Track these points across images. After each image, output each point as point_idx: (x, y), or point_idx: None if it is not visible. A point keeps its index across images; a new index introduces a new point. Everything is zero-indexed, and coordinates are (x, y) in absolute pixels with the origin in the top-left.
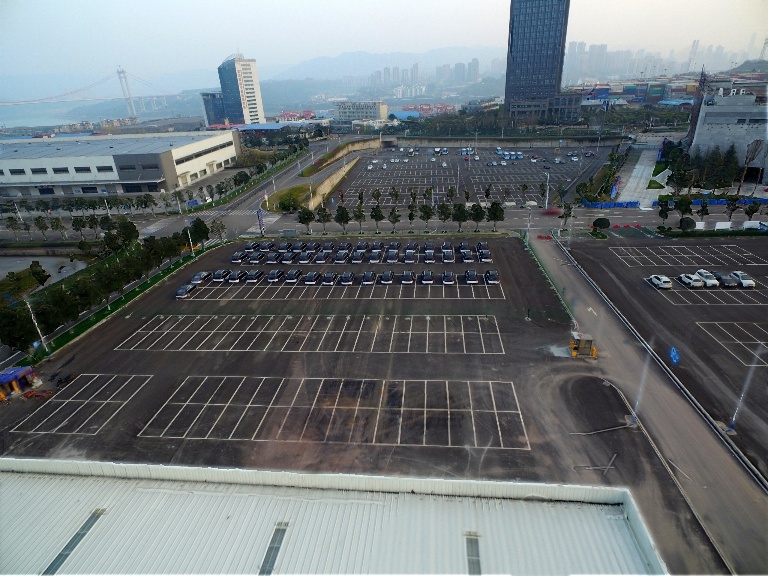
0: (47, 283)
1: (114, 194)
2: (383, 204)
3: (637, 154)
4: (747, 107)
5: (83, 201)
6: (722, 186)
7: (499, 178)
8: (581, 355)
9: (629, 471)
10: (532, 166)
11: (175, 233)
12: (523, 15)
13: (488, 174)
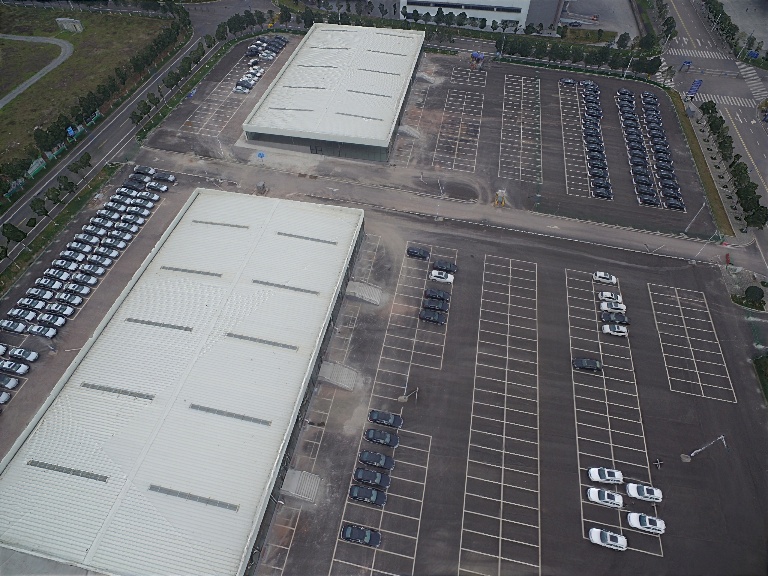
0: (598, 44)
1: None
2: None
3: None
4: None
5: None
6: None
7: None
8: None
9: (419, 184)
10: None
11: (629, 55)
12: None
13: None
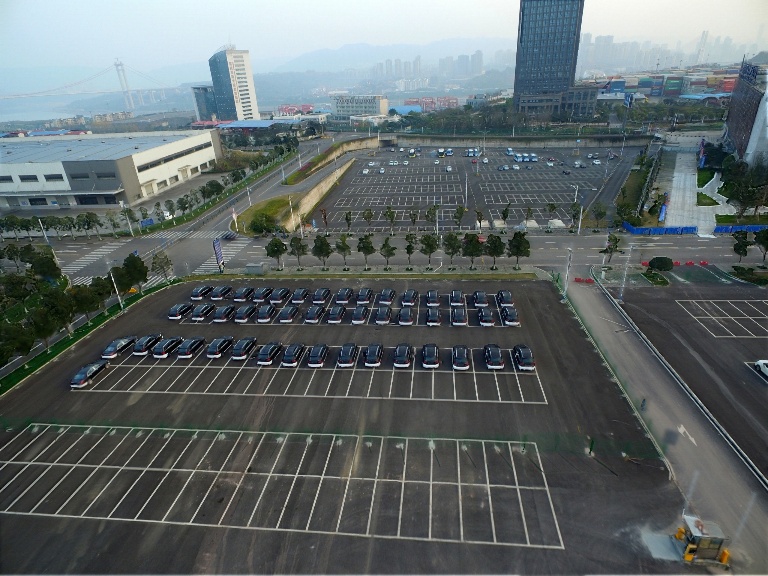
0: None
1: (66, 206)
2: (378, 220)
3: (671, 158)
4: None
5: (14, 220)
6: None
7: (513, 186)
8: (700, 559)
9: None
10: (549, 171)
11: (94, 278)
12: (535, 1)
13: (499, 181)
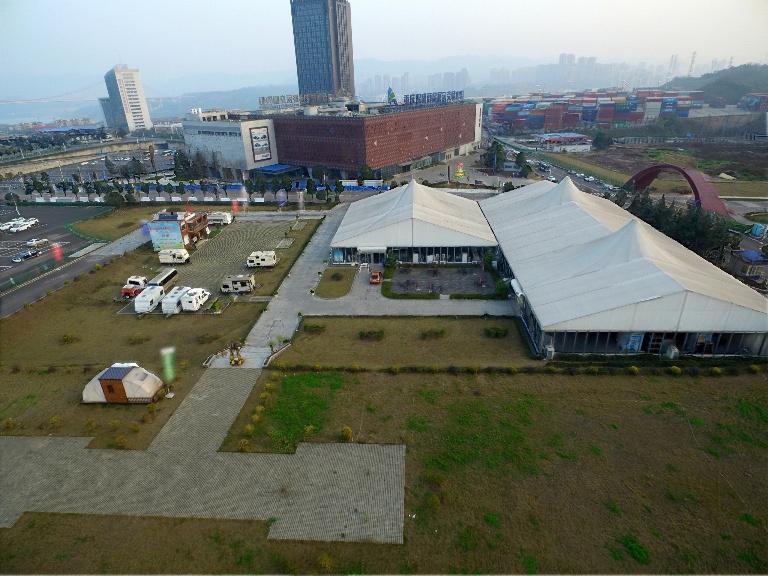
0: None
1: None
2: None
3: None
4: (197, 122)
5: None
6: (189, 179)
7: None
8: None
9: None
10: None
11: None
12: (301, 39)
13: None
